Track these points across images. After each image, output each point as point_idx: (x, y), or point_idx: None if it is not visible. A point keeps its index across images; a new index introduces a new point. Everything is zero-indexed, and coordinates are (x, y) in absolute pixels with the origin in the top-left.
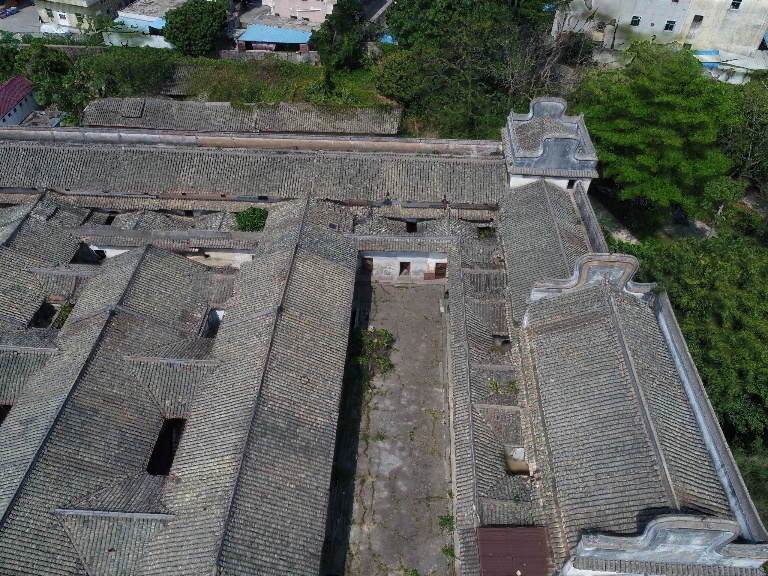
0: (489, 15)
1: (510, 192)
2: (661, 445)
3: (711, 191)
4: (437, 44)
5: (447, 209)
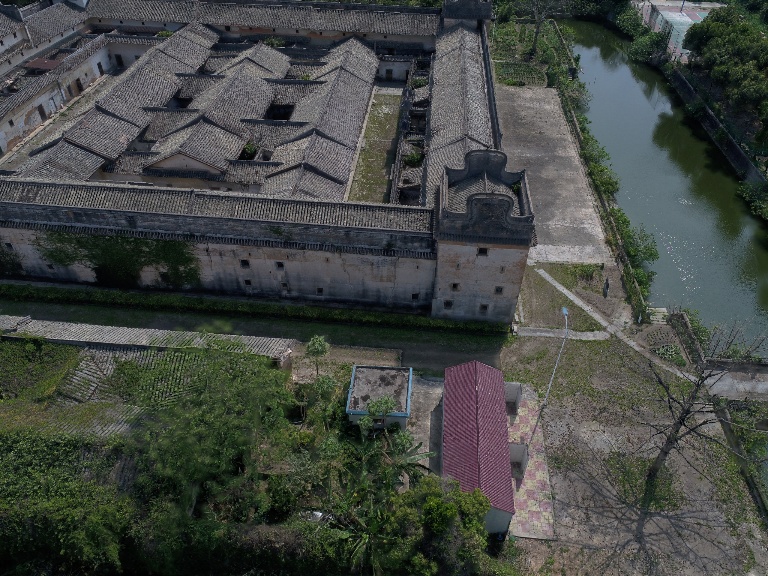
0: None
1: None
2: None
3: None
4: None
5: None
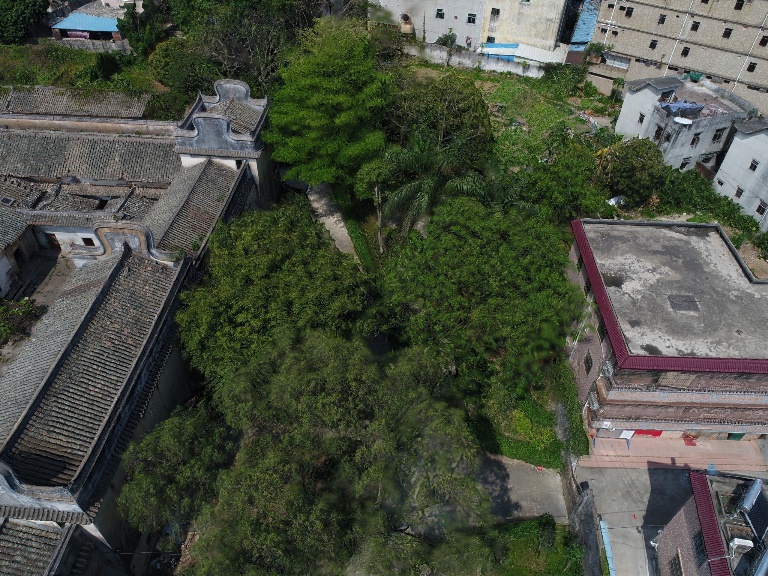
0: (244, 3)
1: (183, 171)
2: (52, 397)
3: (359, 172)
4: (210, 32)
5: (131, 187)
